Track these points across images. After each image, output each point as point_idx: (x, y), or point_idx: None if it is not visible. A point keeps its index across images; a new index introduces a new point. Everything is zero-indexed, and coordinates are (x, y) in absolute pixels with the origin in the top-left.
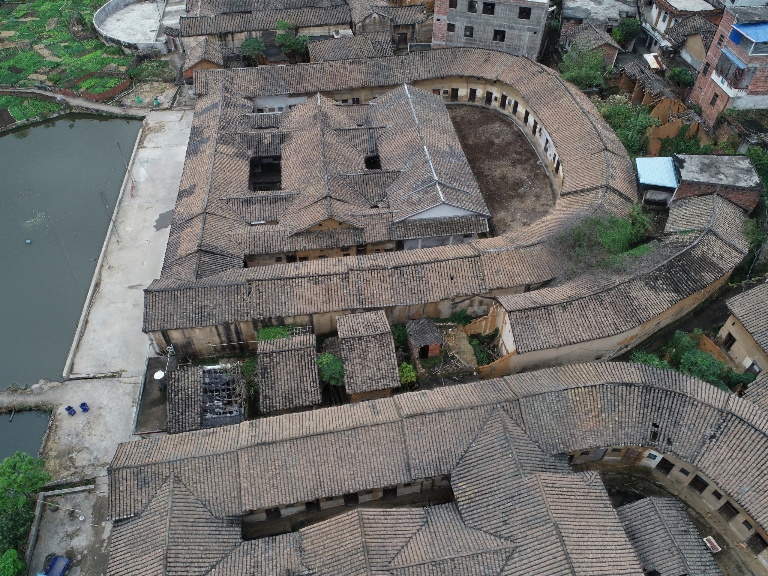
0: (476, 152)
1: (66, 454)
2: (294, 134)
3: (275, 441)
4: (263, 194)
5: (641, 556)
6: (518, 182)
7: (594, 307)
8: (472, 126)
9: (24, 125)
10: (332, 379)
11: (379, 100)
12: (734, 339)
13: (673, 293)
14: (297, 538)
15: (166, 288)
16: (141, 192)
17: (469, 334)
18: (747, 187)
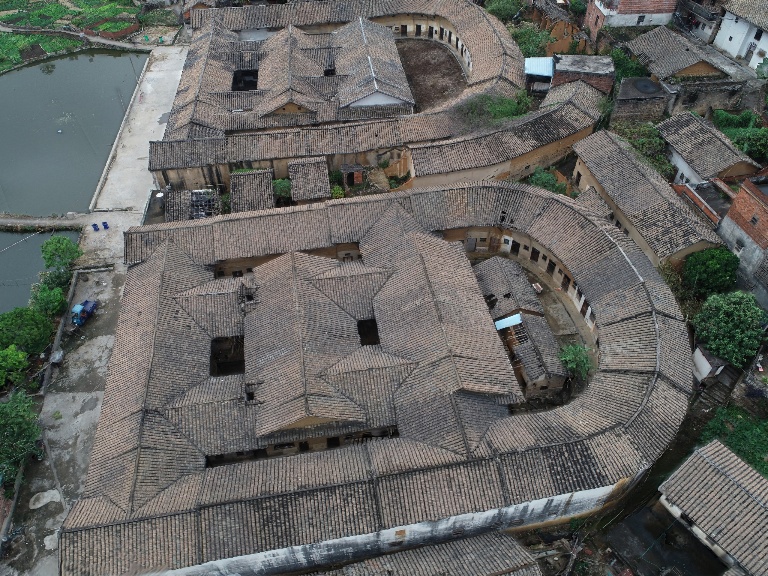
0: (415, 70)
1: (93, 252)
2: (269, 53)
3: (238, 218)
4: (242, 91)
5: (484, 288)
6: (444, 88)
7: (474, 147)
8: (415, 53)
9: (53, 56)
10: (282, 192)
11: (339, 30)
12: (580, 175)
13: (535, 141)
14: (252, 277)
15: (165, 141)
16: (148, 100)
17: (388, 176)
18: (603, 74)
